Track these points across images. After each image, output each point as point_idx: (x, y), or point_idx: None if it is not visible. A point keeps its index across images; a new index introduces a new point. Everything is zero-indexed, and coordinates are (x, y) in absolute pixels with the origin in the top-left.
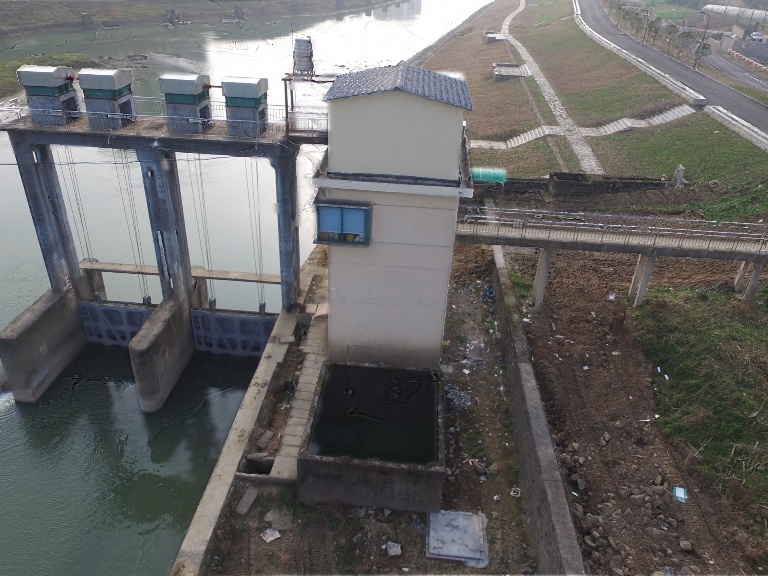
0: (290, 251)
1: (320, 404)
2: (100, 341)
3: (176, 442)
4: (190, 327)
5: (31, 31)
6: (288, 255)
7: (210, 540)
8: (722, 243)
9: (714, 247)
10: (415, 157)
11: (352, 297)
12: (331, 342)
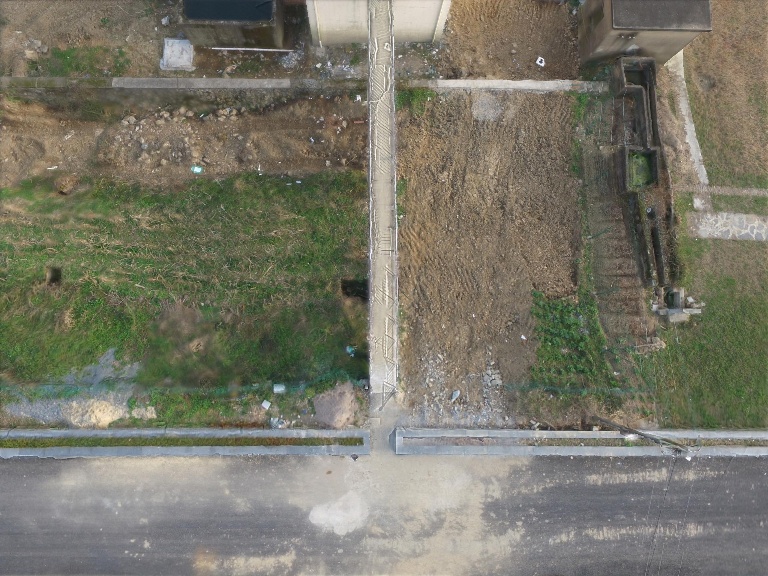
0: None
1: None
2: None
3: None
4: None
5: None
6: None
7: None
8: None
9: None
10: None
11: None
12: None
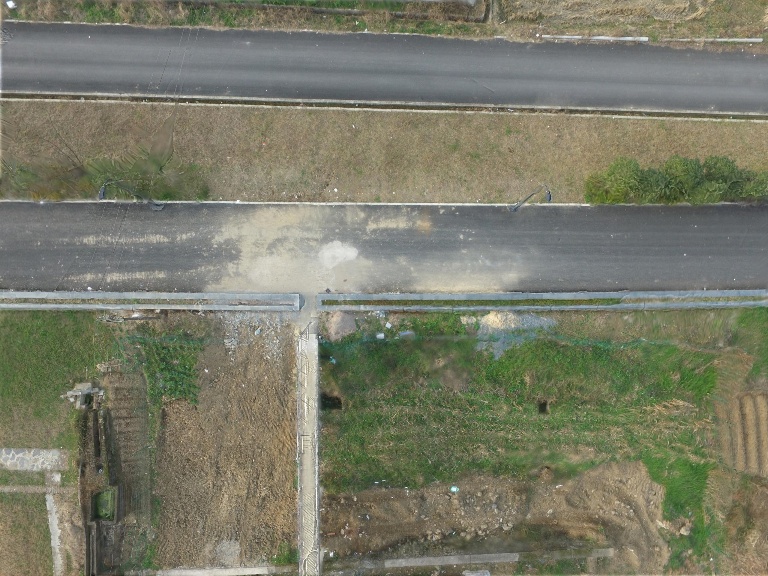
0: None
1: None
2: None
3: None
4: None
5: None
6: None
7: None
8: None
9: None
10: None
11: None
12: None
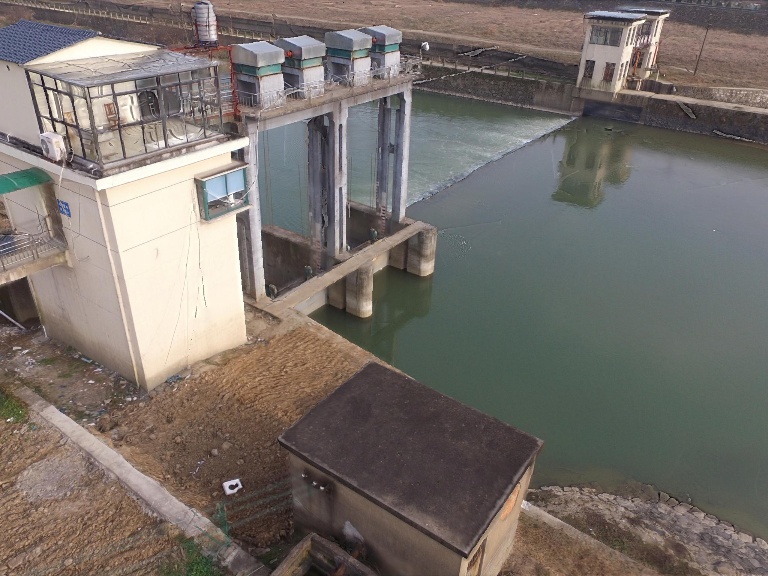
0: None
1: None
2: None
3: None
4: None
5: None
6: None
7: None
8: None
9: None
10: None
11: None
12: None
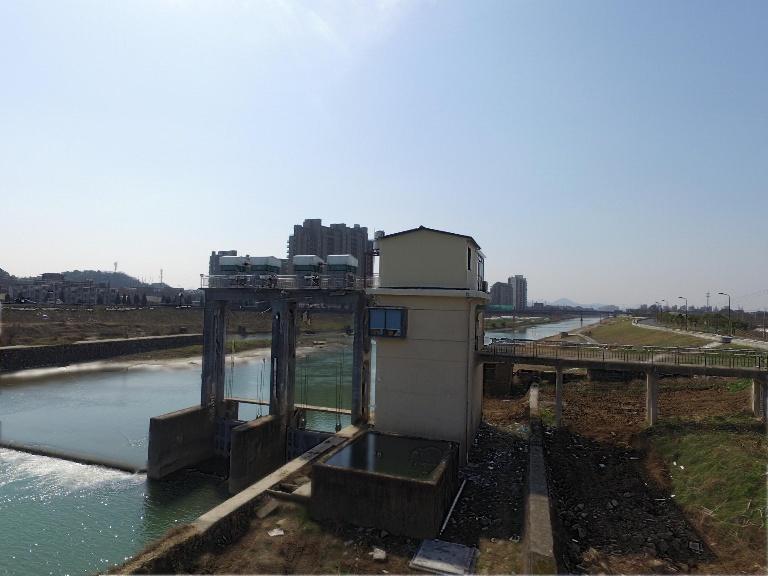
0: (360, 373)
1: (348, 448)
2: (221, 453)
3: None
4: (284, 442)
5: (262, 333)
6: (358, 377)
7: (224, 519)
8: (717, 360)
9: (711, 364)
10: (436, 274)
11: (392, 387)
12: (376, 429)
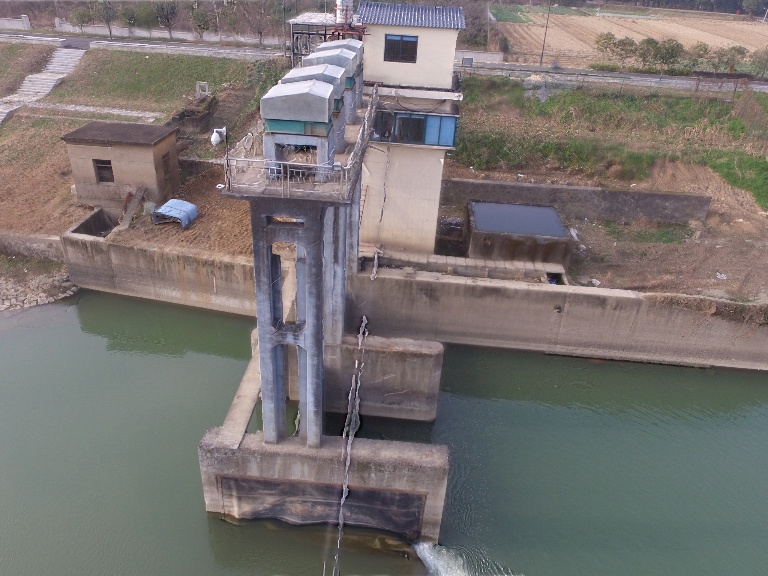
0: None
1: None
2: None
3: (482, 379)
4: None
5: None
6: None
7: None
8: None
9: None
10: None
11: None
12: None
